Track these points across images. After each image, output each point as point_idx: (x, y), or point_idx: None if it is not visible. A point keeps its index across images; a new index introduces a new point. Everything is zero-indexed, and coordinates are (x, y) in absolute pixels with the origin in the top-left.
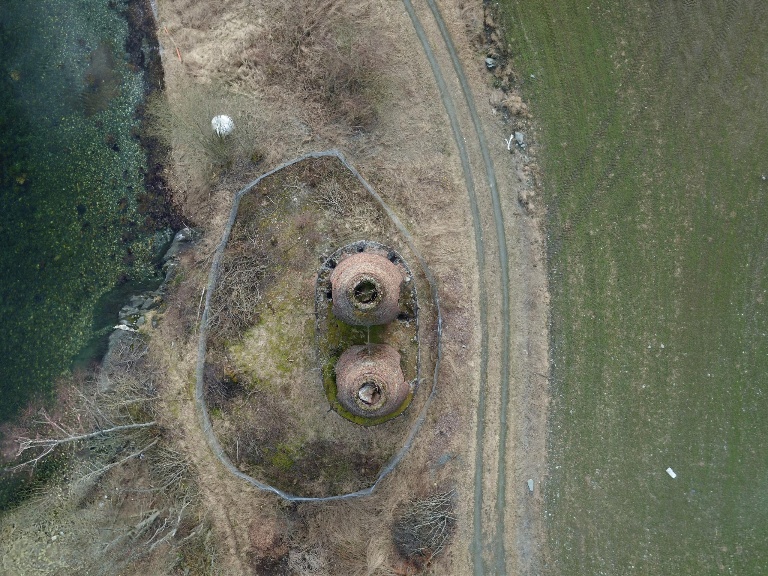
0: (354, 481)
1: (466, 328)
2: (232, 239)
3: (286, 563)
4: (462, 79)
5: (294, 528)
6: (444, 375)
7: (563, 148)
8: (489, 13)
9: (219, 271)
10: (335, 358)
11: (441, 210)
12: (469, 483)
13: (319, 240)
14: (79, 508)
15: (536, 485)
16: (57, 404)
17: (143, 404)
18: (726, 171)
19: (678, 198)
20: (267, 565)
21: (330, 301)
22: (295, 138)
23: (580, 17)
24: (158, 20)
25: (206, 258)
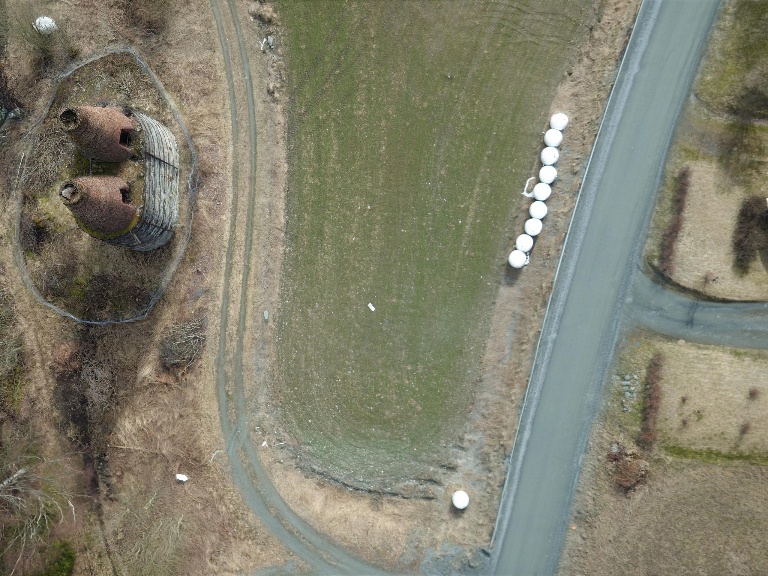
0: (133, 310)
1: (220, 189)
2: (49, 117)
3: (79, 375)
4: None
5: (87, 347)
6: (199, 224)
7: (302, 50)
8: None
9: (35, 140)
10: None
11: (207, 96)
12: (217, 311)
13: None
14: None
15: (270, 315)
16: None
17: None
18: (422, 71)
19: (385, 91)
20: (65, 377)
21: None
22: (103, 38)
23: None
24: None
25: (27, 130)
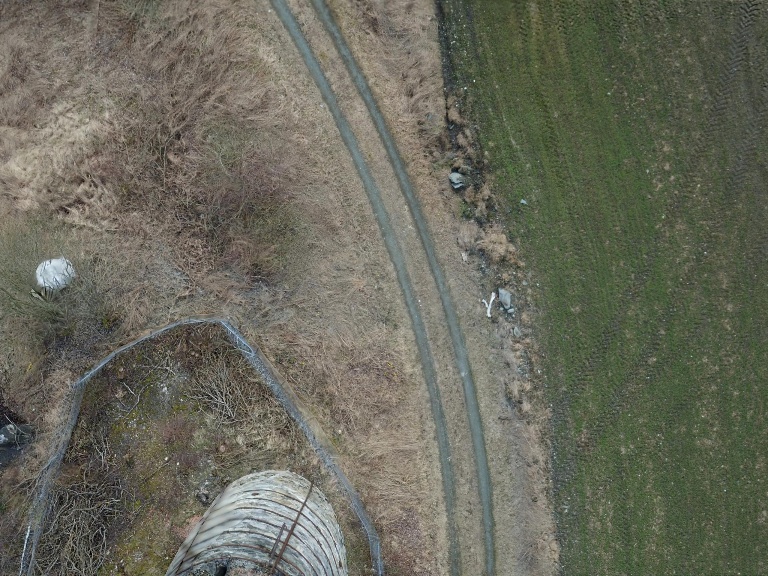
0: None
1: None
2: (73, 447)
3: None
4: (413, 207)
5: None
6: None
7: (574, 315)
8: (453, 103)
9: (49, 504)
10: None
11: (385, 414)
12: None
13: (195, 464)
14: None
15: None
16: None
17: None
18: None
19: (761, 398)
20: None
21: None
22: (165, 292)
23: (596, 109)
24: None
25: (33, 479)
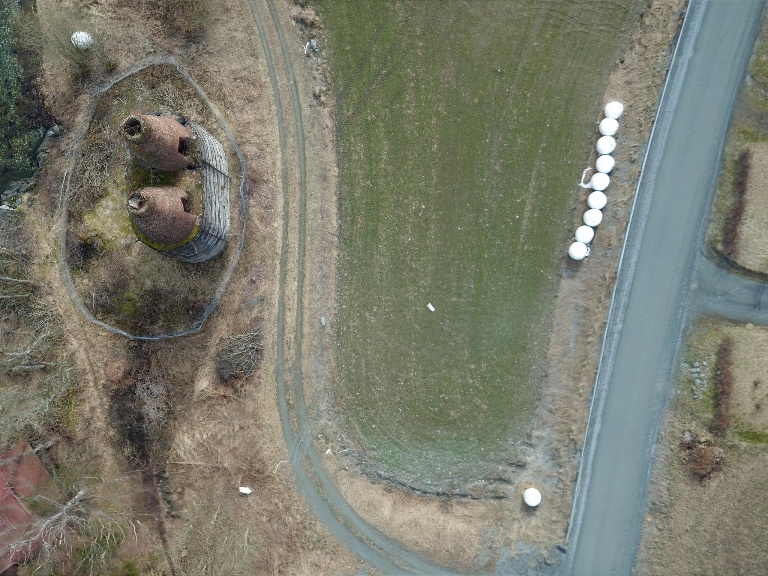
0: (186, 323)
1: (271, 196)
2: (90, 132)
3: (134, 392)
4: None
5: (140, 364)
6: (251, 232)
7: (347, 51)
8: None
9: (77, 156)
10: None
11: (252, 103)
12: (273, 319)
13: None
14: None
15: (328, 321)
16: None
17: (19, 267)
18: (471, 66)
19: (435, 89)
20: (119, 395)
21: None
22: (141, 50)
23: None
24: None
25: (69, 147)
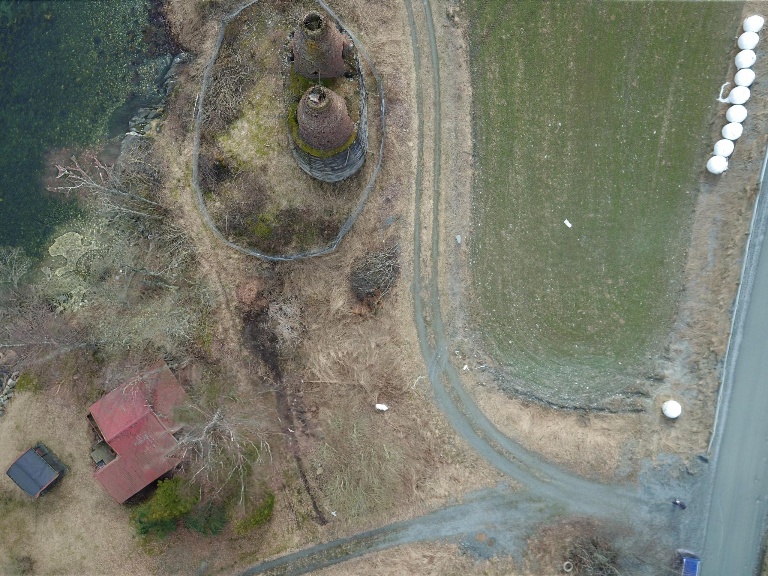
0: (320, 244)
1: (406, 116)
2: (220, 57)
3: (267, 313)
4: None
5: (273, 285)
6: (388, 151)
7: None
8: None
9: (209, 80)
10: (297, 103)
11: (385, 24)
12: (410, 238)
13: None
14: (99, 281)
15: (463, 239)
16: (80, 198)
17: (150, 191)
18: None
19: (571, 7)
20: (252, 317)
21: (293, 62)
22: None
23: None
24: None
25: (199, 72)
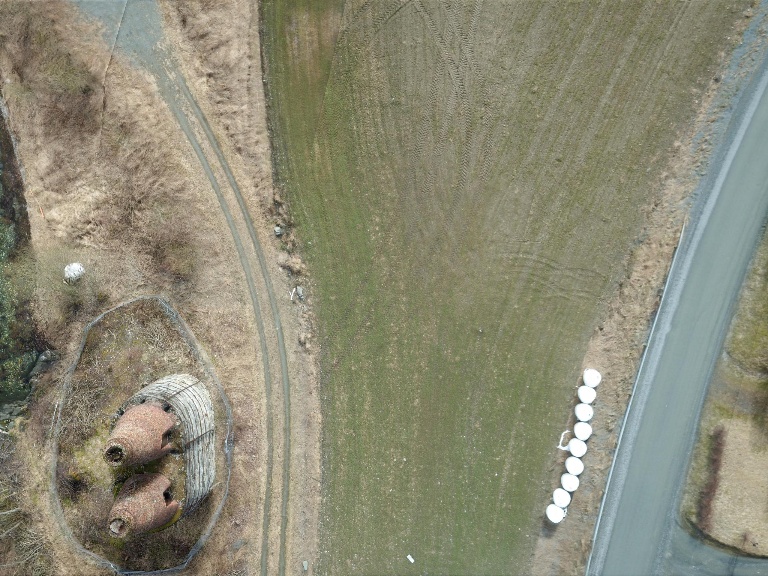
0: (172, 559)
1: (256, 442)
2: (81, 362)
3: None
4: (256, 243)
5: None
6: (236, 479)
7: (332, 301)
8: (277, 192)
9: (68, 390)
10: (121, 484)
11: (238, 347)
12: (257, 564)
13: (142, 370)
14: None
15: (310, 565)
16: None
17: (10, 493)
18: (453, 324)
19: (417, 344)
20: None
21: None
22: (132, 282)
23: (345, 198)
24: (25, 184)
25: (60, 378)
